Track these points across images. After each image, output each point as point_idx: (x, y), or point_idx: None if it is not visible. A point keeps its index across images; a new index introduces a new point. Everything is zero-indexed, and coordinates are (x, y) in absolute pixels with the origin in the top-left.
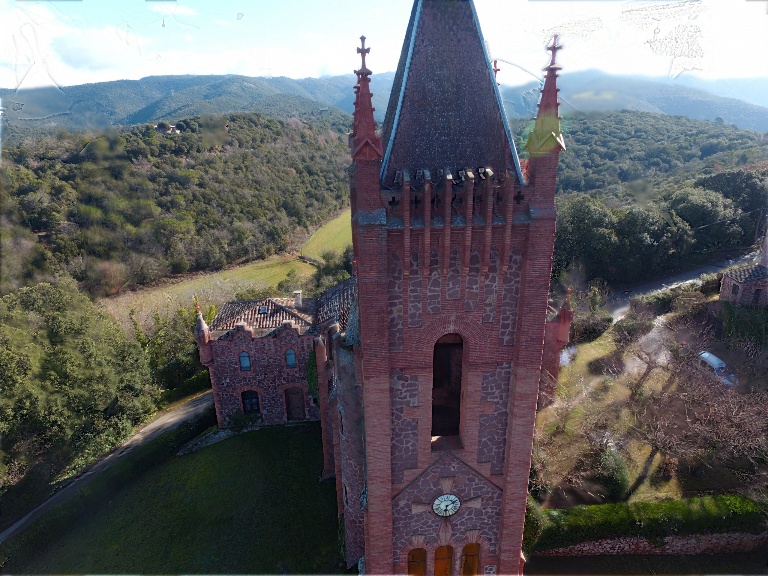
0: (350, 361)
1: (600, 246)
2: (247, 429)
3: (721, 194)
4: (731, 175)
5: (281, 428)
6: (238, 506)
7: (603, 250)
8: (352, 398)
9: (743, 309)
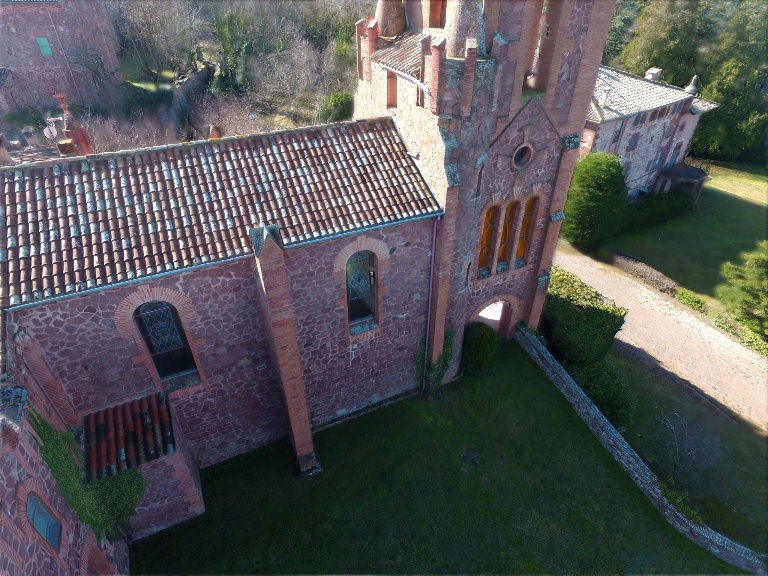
0: None
1: None
2: None
3: None
4: None
5: None
6: None
7: None
8: None
9: None
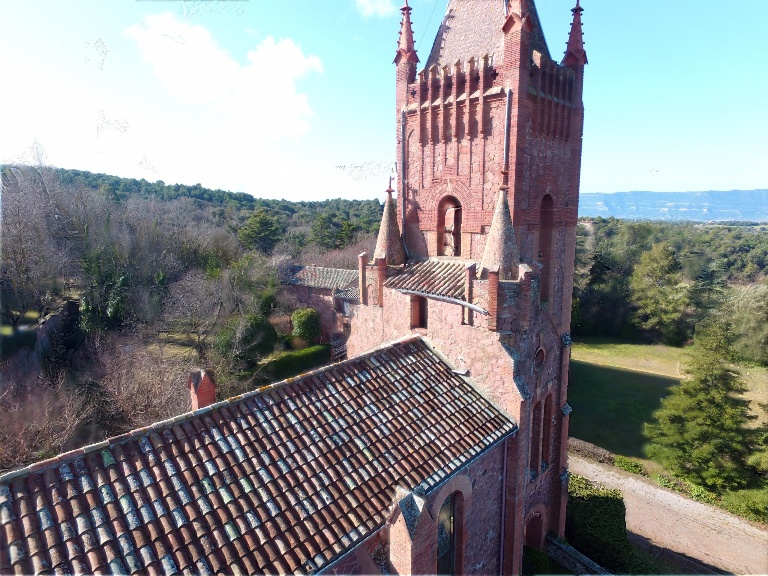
0: None
1: None
2: None
3: None
4: None
5: None
6: None
7: None
8: None
9: None
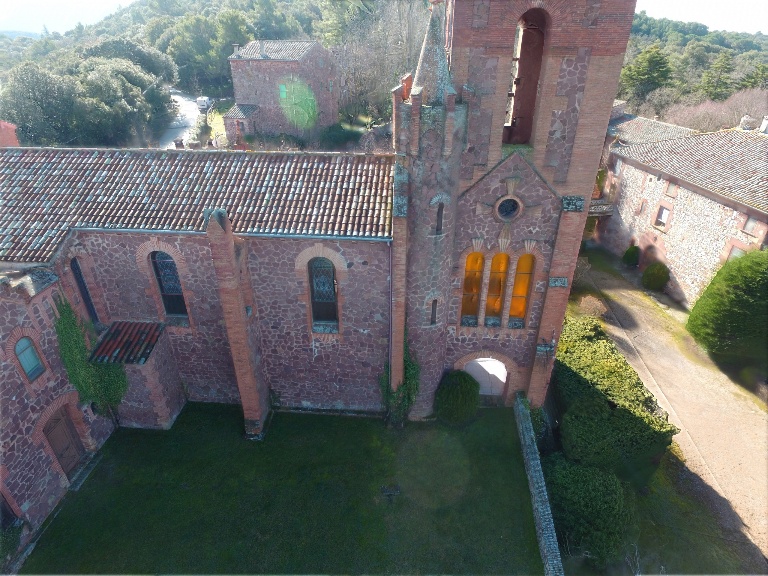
0: (464, 119)
1: (98, 119)
2: (11, 573)
3: (129, 60)
4: (116, 43)
5: (74, 500)
6: (237, 575)
7: (104, 123)
8: (458, 172)
9: (267, 134)
